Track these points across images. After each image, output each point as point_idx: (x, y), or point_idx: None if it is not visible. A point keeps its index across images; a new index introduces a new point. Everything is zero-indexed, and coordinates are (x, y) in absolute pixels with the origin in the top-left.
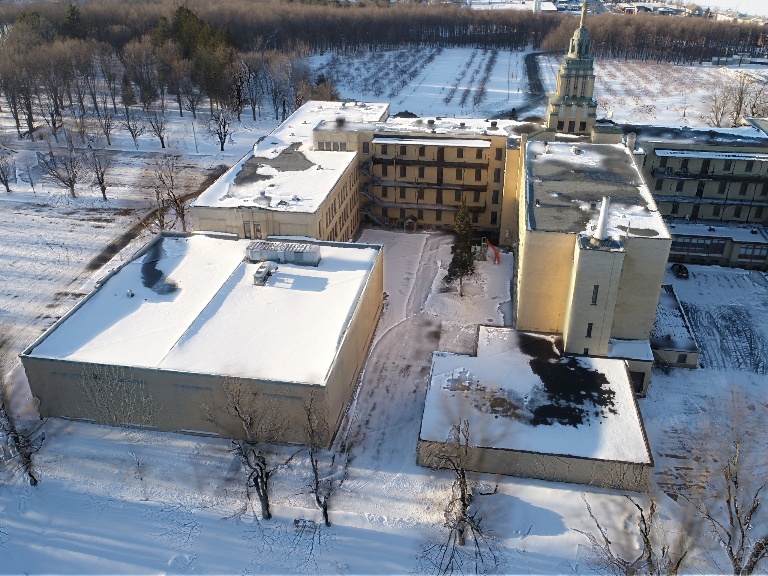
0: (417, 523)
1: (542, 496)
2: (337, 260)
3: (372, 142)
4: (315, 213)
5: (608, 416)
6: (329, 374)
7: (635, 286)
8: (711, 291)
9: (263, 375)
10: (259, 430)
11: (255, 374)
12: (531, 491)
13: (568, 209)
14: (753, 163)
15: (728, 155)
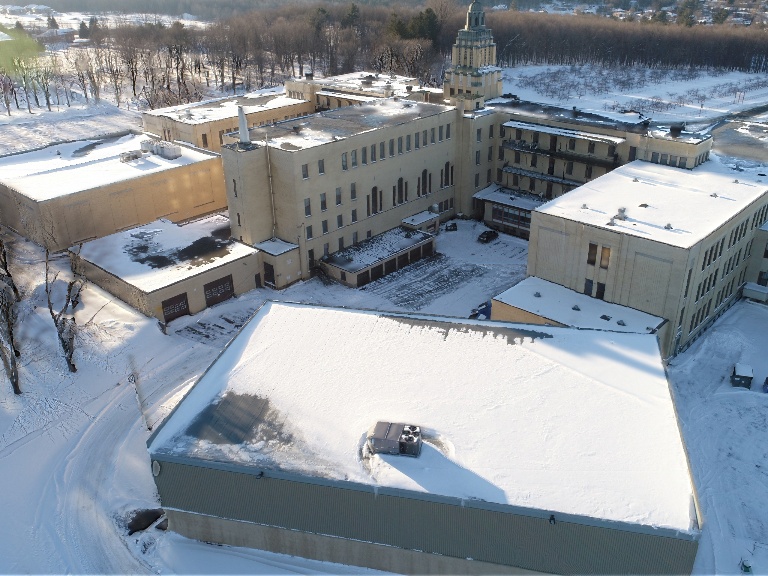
0: (18, 287)
1: (93, 298)
2: (186, 159)
3: (314, 93)
4: (194, 125)
5: (181, 269)
6: (51, 198)
7: (282, 192)
8: (486, 255)
9: (29, 193)
10: (29, 232)
11: (27, 192)
12: (91, 294)
13: (285, 130)
14: (594, 144)
15: (567, 132)
